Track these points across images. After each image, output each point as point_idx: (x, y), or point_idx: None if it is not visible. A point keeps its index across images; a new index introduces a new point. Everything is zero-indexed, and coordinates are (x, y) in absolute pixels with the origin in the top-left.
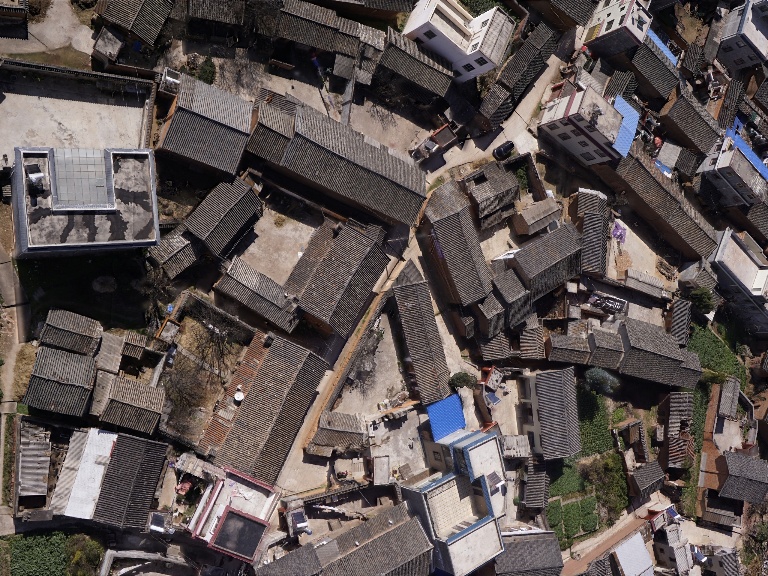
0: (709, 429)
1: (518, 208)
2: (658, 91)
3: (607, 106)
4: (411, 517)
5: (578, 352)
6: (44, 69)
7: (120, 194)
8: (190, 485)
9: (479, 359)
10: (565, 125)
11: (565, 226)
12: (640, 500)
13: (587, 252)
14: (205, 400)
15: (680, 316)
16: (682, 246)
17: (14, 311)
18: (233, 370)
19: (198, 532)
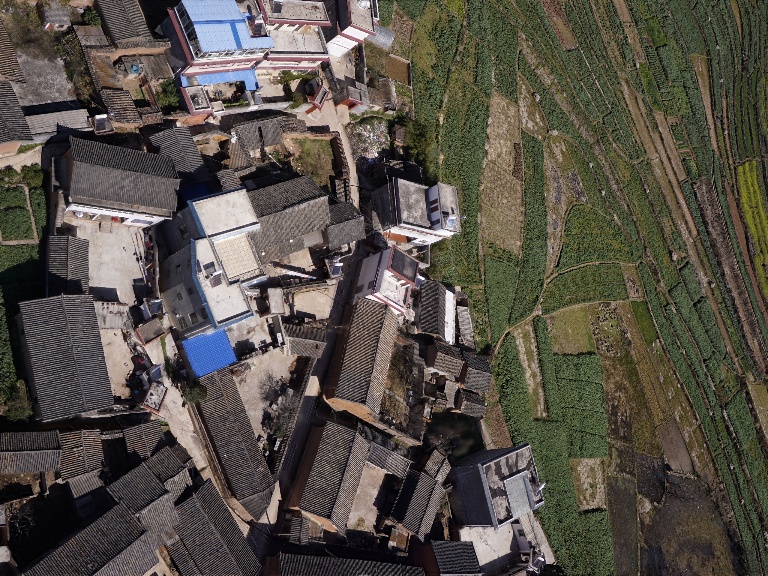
0: None
1: None
2: None
3: None
4: None
5: (4, 449)
6: (512, 573)
7: (502, 493)
8: None
9: None
10: None
11: None
12: None
13: None
14: None
15: None
16: None
17: None
18: None
19: None
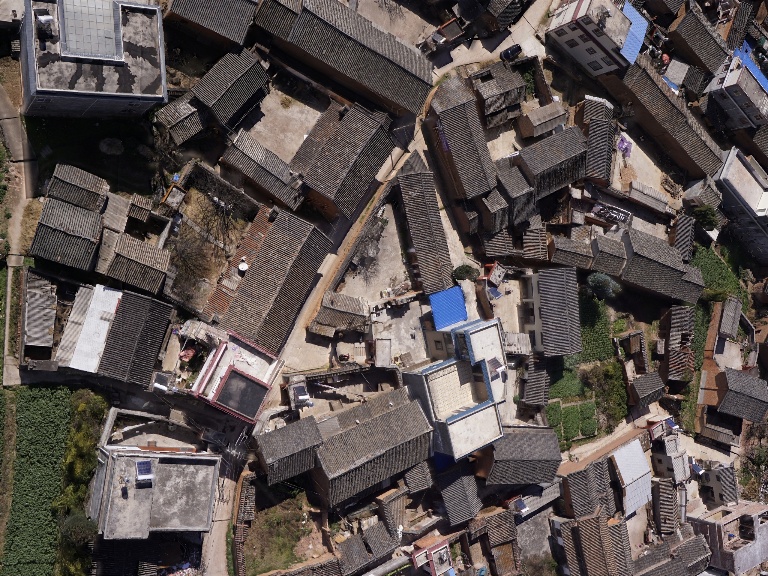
0: (710, 347)
1: (524, 111)
2: (667, 5)
3: (616, 10)
4: (412, 401)
5: (581, 256)
6: None
7: (128, 47)
8: (194, 352)
9: (482, 257)
10: (573, 30)
11: (571, 128)
12: (639, 408)
13: (592, 158)
14: (209, 272)
15: (684, 232)
16: (687, 164)
17: (22, 166)
18: (238, 244)
19: (201, 391)
